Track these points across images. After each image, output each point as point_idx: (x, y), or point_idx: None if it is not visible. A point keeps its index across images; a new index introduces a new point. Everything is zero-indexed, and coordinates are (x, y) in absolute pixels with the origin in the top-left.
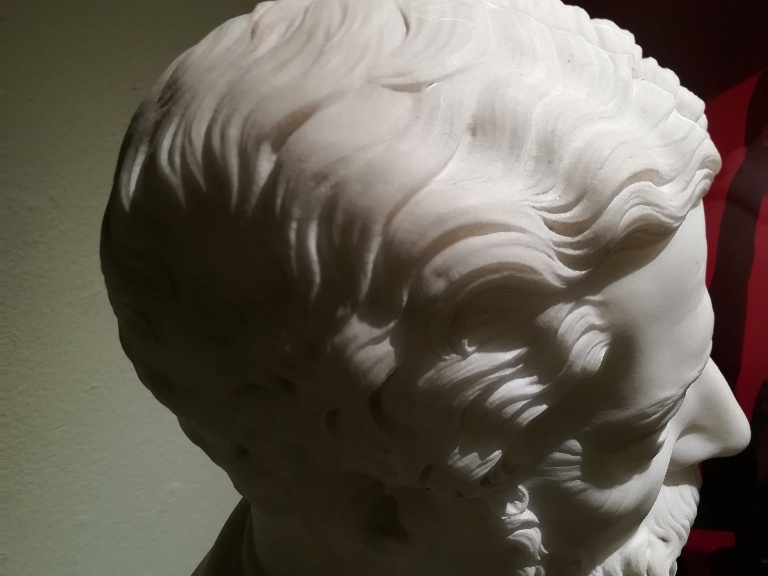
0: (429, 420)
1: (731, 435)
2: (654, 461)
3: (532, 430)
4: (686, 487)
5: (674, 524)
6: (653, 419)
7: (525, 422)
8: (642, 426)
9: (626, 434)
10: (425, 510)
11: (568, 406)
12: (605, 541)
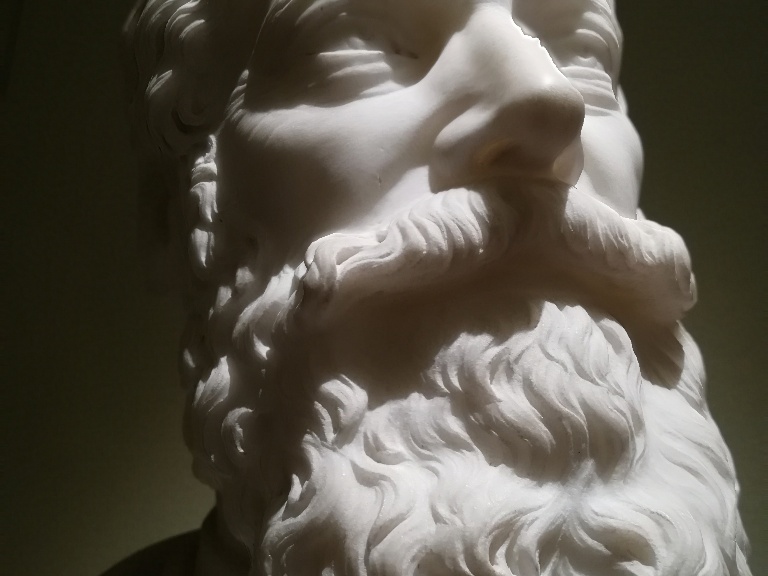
0: (140, 55)
1: (508, 88)
2: (352, 106)
3: (215, 65)
4: (459, 190)
5: (403, 219)
6: (286, 9)
7: (184, 35)
8: (278, 20)
9: (271, 39)
10: (173, 191)
11: (240, 34)
12: (296, 224)
